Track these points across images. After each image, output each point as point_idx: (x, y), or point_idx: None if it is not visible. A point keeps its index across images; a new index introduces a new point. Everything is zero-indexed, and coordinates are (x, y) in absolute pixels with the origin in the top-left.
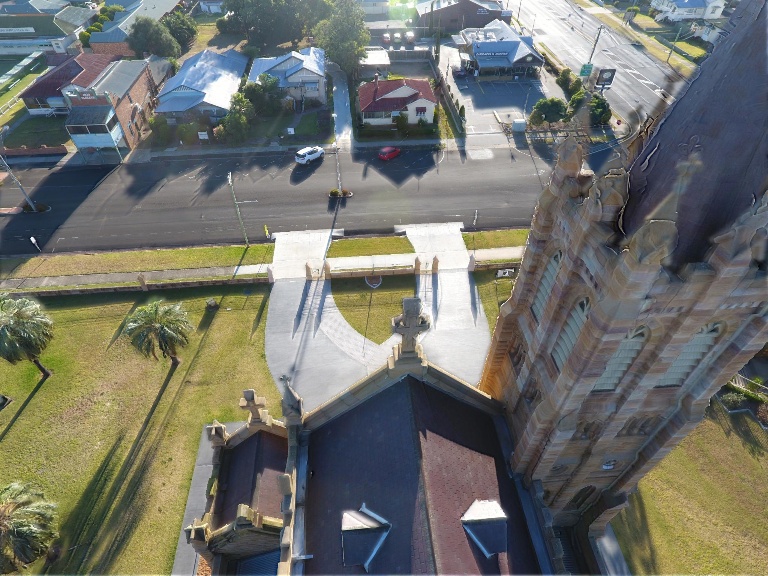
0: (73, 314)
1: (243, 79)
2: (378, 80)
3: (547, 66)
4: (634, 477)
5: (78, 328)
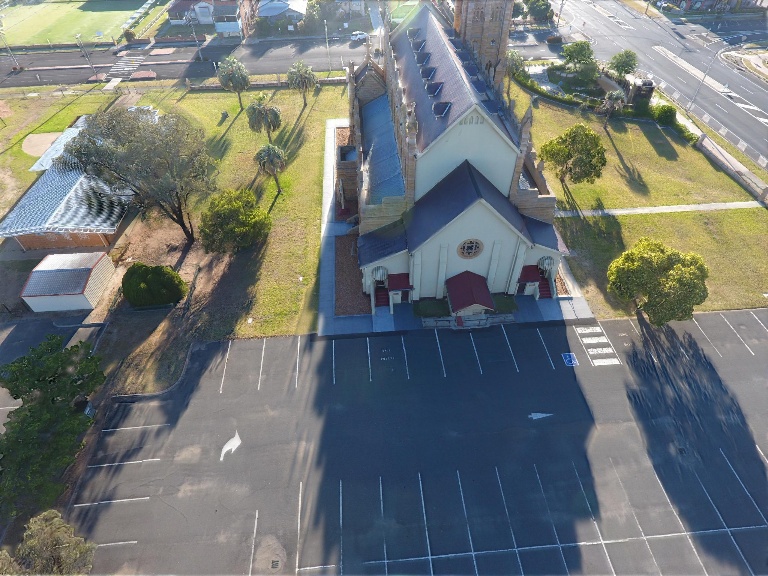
0: (245, 93)
1: None
2: None
3: None
4: (501, 46)
5: None
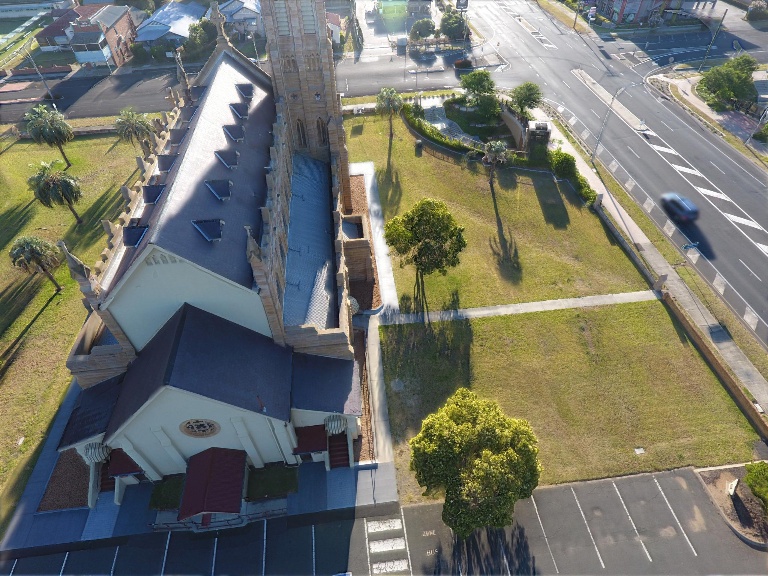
0: (83, 142)
1: (201, 20)
2: None
3: (440, 6)
4: (328, 100)
5: (87, 147)
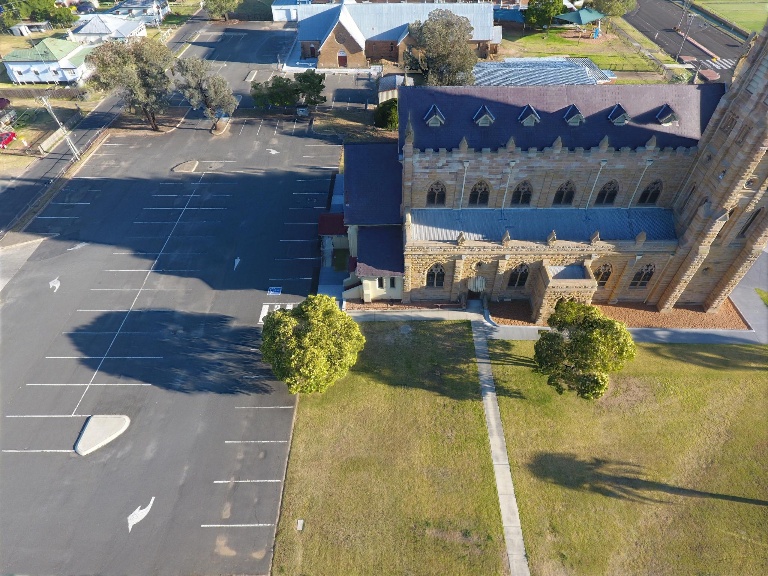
0: None
1: None
2: None
3: None
4: None
5: None
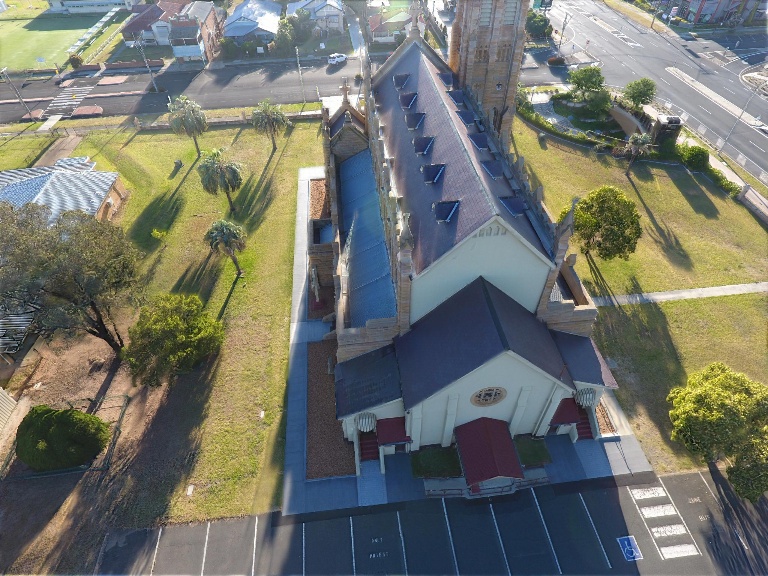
0: (204, 134)
1: (282, 16)
2: (383, 12)
3: None
4: (509, 91)
5: (210, 139)
